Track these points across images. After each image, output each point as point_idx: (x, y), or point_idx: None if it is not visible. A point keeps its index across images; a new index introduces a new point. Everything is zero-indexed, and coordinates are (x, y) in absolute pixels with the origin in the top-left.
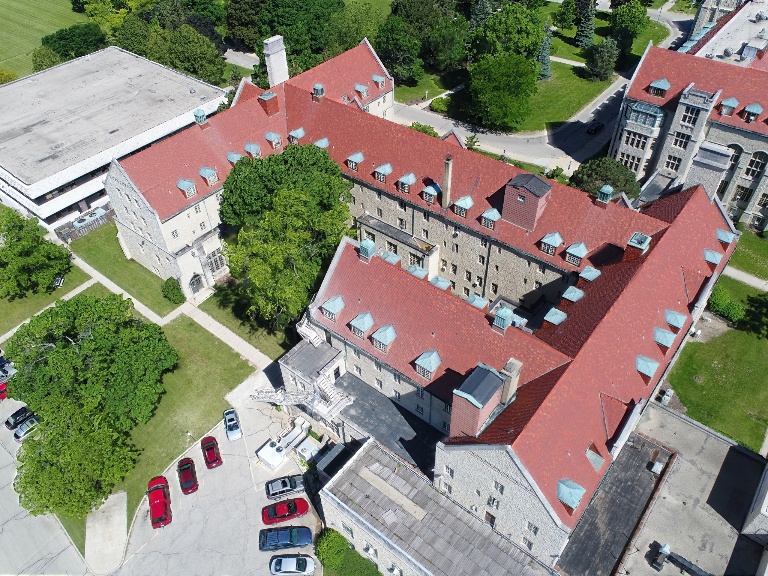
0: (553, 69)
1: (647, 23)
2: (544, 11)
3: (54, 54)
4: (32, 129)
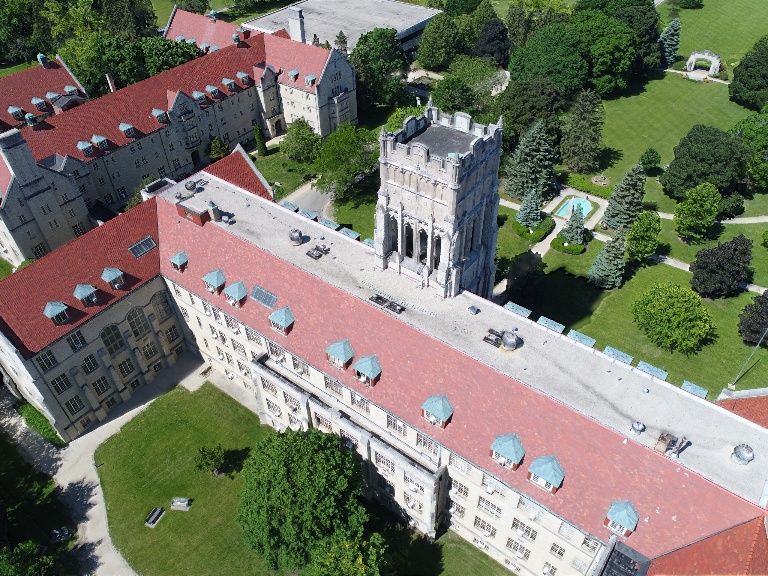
0: (501, 243)
1: (677, 340)
2: (754, 260)
3: (437, 1)
4: (312, 13)
